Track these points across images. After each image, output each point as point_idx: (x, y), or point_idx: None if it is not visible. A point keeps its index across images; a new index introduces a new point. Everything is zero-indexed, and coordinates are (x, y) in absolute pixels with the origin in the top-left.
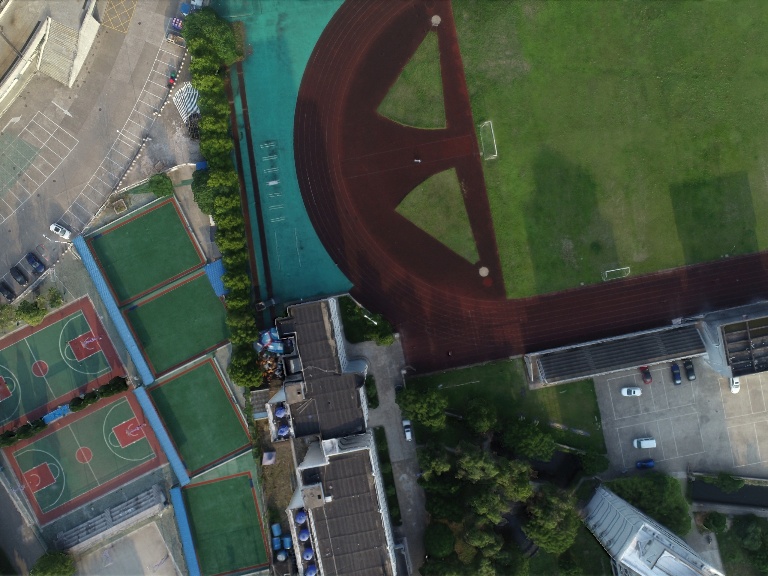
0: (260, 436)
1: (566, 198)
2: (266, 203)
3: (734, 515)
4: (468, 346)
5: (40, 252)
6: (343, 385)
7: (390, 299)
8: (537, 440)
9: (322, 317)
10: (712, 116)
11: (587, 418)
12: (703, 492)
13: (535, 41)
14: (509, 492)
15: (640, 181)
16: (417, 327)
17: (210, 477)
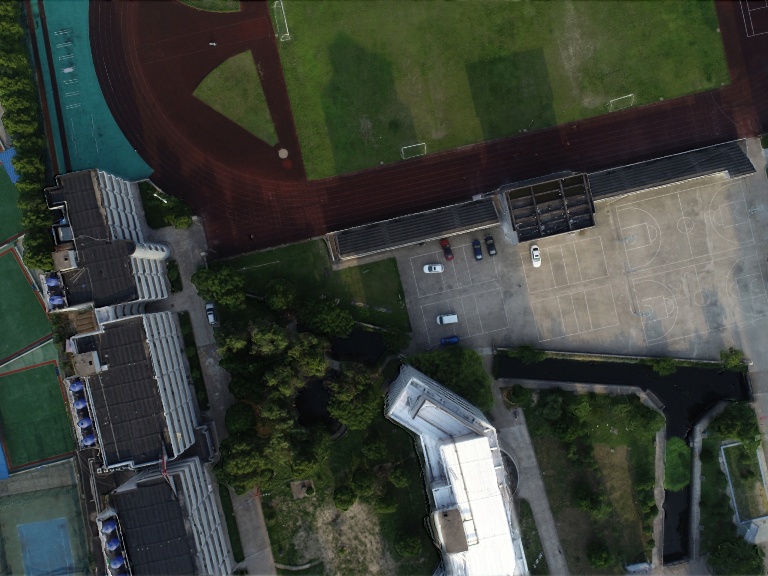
0: (64, 324)
1: (363, 77)
2: (63, 91)
3: (540, 389)
4: (270, 228)
5: None
6: (115, 253)
7: (191, 184)
8: (333, 315)
9: (92, 186)
10: None
11: (391, 297)
12: (510, 368)
13: None
14: (304, 366)
15: (436, 58)
16: (218, 211)
17: (16, 367)
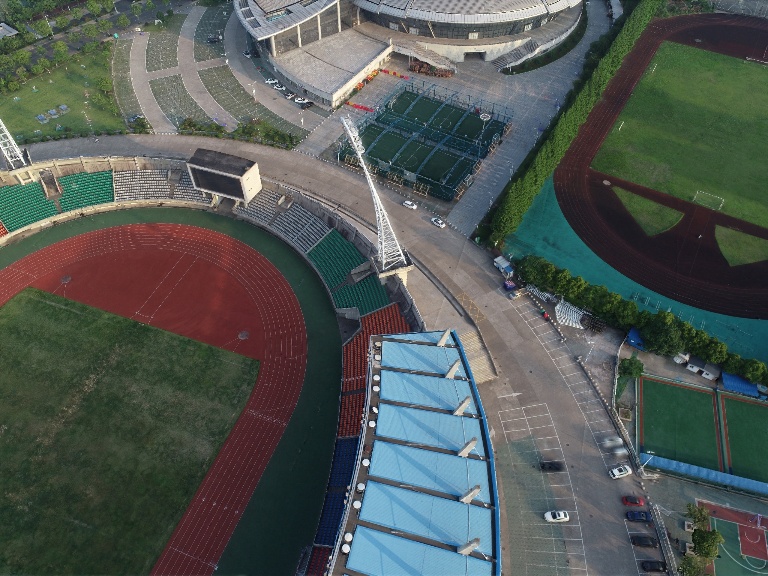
0: None
1: None
2: None
3: None
4: None
5: (633, 501)
6: None
7: None
8: None
9: None
10: (748, 123)
11: None
12: None
13: (652, 156)
14: None
15: None
16: None
17: None
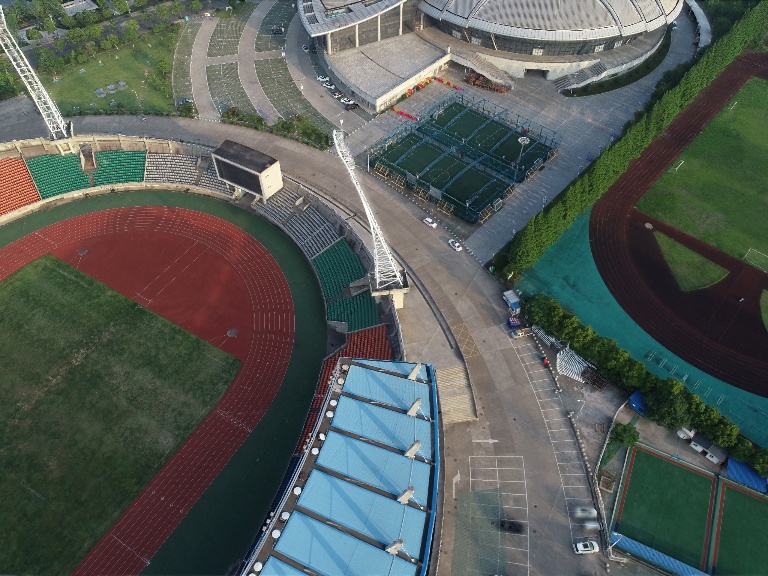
0: None
1: None
2: None
3: None
4: None
5: None
6: None
7: None
8: None
9: None
10: None
11: None
12: None
13: (708, 203)
14: None
15: None
16: None
17: None
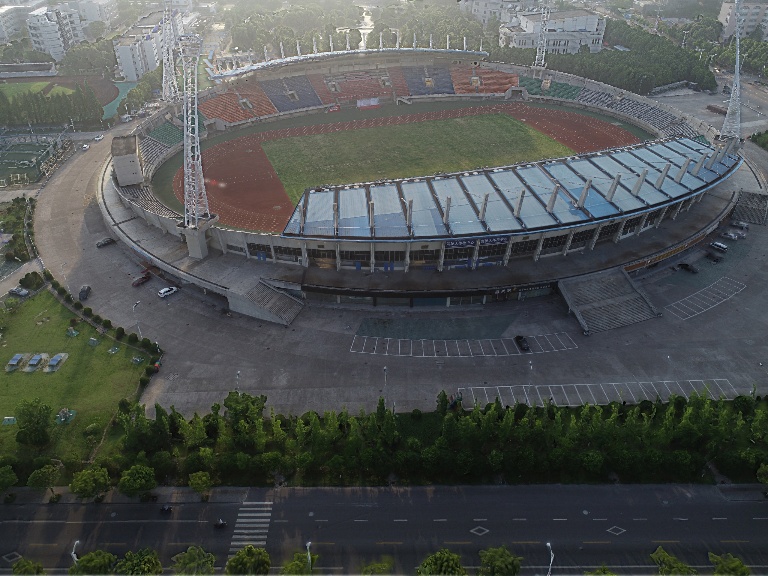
0: None
1: None
2: None
3: None
4: None
5: None
6: None
7: (100, 82)
8: None
9: None
10: None
11: None
12: None
13: None
14: None
15: None
16: None
17: None
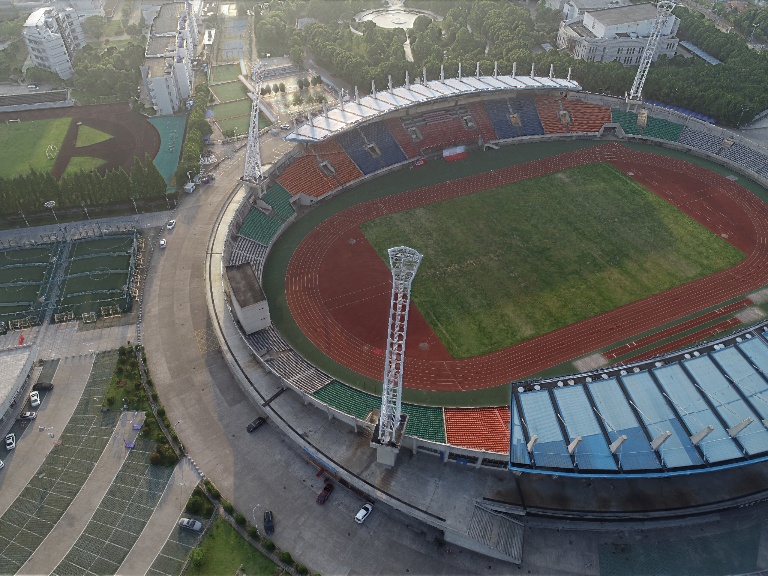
0: None
1: None
2: None
3: None
4: None
5: None
6: None
7: (130, 117)
8: None
9: None
10: None
11: None
12: None
13: None
14: None
15: None
16: (121, 111)
17: None
